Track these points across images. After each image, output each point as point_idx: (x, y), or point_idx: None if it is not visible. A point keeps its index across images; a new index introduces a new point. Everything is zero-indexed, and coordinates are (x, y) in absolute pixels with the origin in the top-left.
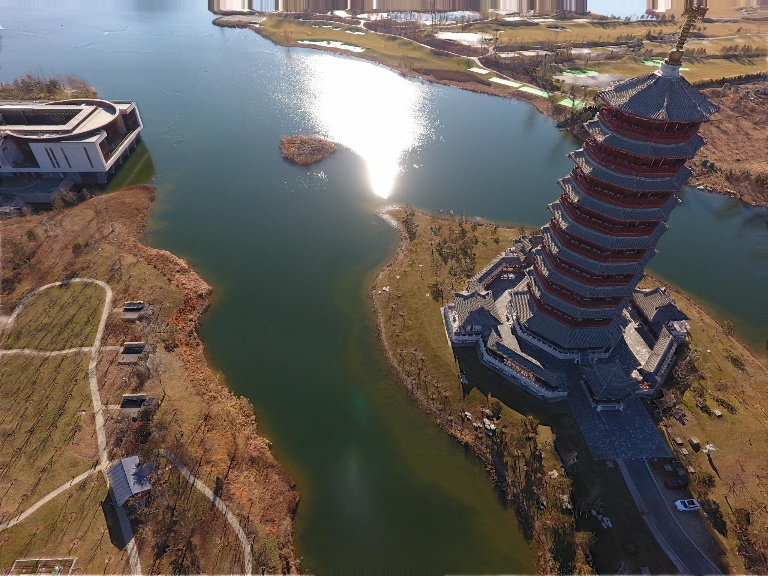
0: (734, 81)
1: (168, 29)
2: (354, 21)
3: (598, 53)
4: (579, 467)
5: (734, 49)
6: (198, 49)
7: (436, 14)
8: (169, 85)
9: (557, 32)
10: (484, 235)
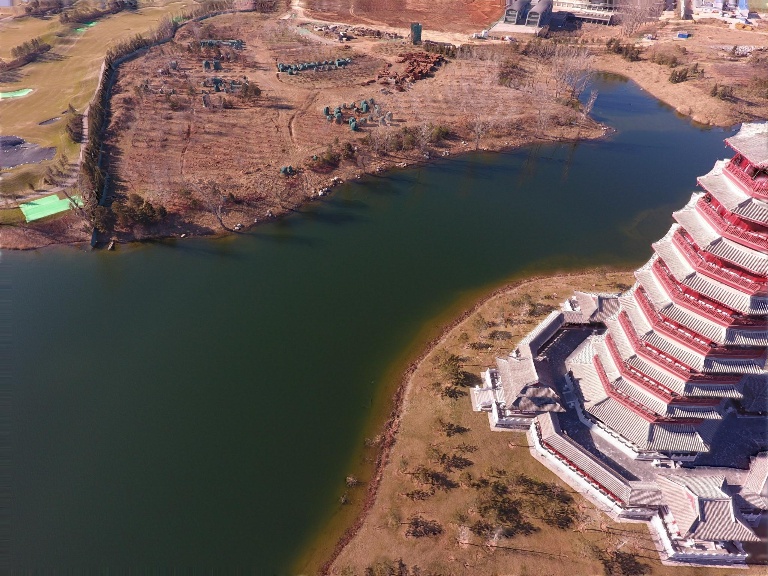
0: (108, 81)
1: None
2: None
3: None
4: None
5: (25, 48)
6: None
7: None
8: None
9: None
10: (436, 443)
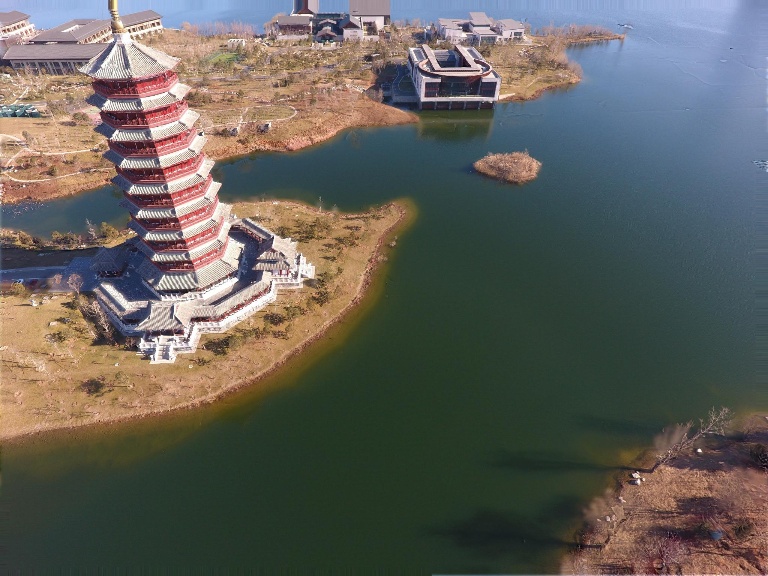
0: None
1: None
2: None
3: None
4: (76, 252)
5: None
6: (749, 99)
7: None
8: (619, 101)
9: None
10: None
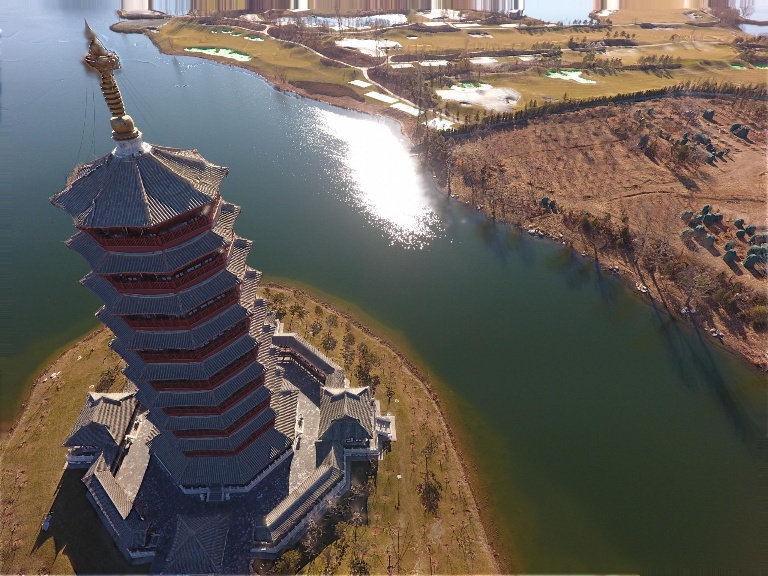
0: (632, 97)
1: (54, 35)
2: (259, 26)
3: (504, 63)
4: None
5: (652, 59)
6: (69, 58)
7: (342, 19)
8: (4, 100)
9: (467, 39)
10: None
